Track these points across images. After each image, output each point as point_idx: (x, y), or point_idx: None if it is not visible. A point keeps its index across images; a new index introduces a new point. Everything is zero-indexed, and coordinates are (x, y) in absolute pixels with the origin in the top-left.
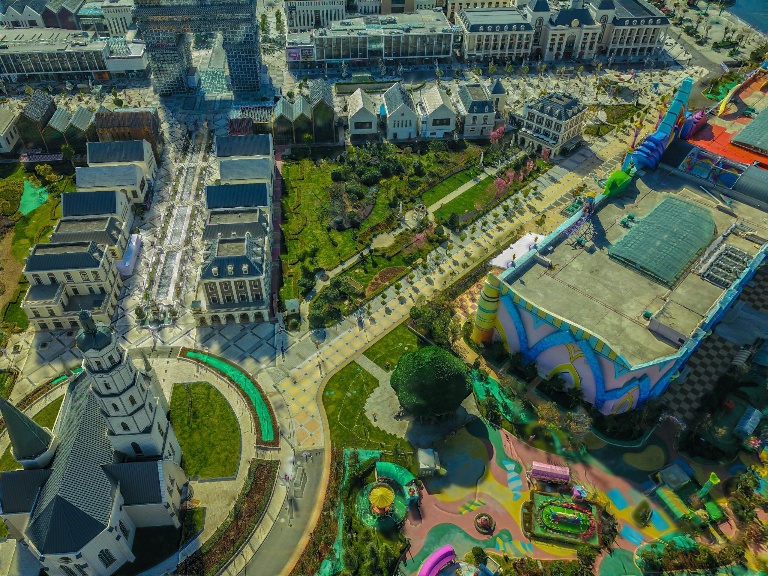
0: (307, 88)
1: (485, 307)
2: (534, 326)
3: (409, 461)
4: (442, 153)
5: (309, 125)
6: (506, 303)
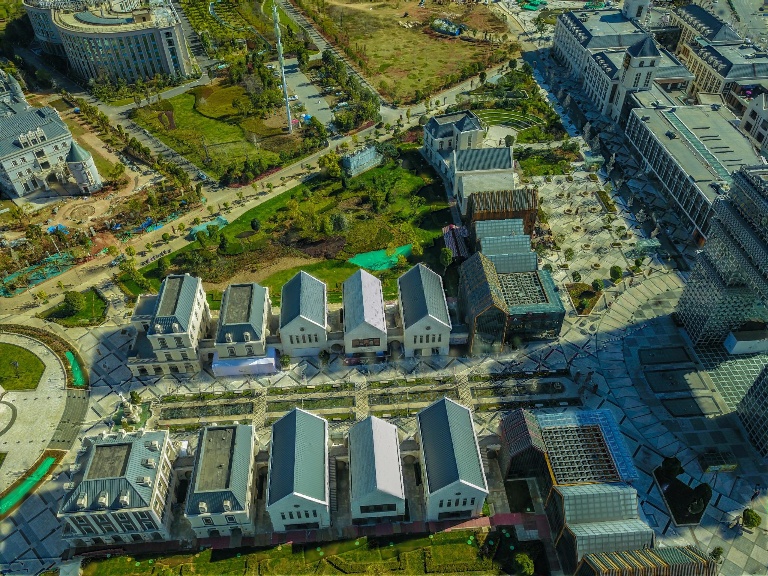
0: None
1: None
2: None
3: None
4: None
5: (575, 562)
6: None
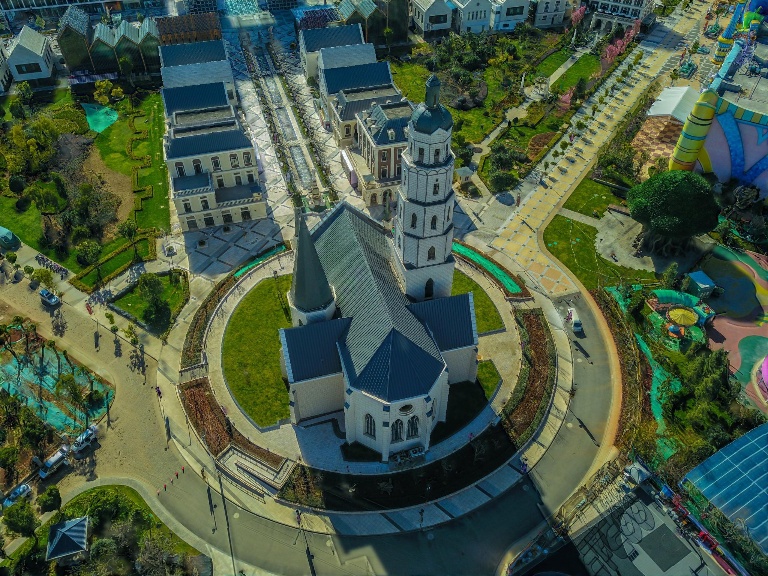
0: None
1: (696, 133)
2: (757, 142)
3: (687, 283)
4: None
5: (383, 22)
6: (725, 122)
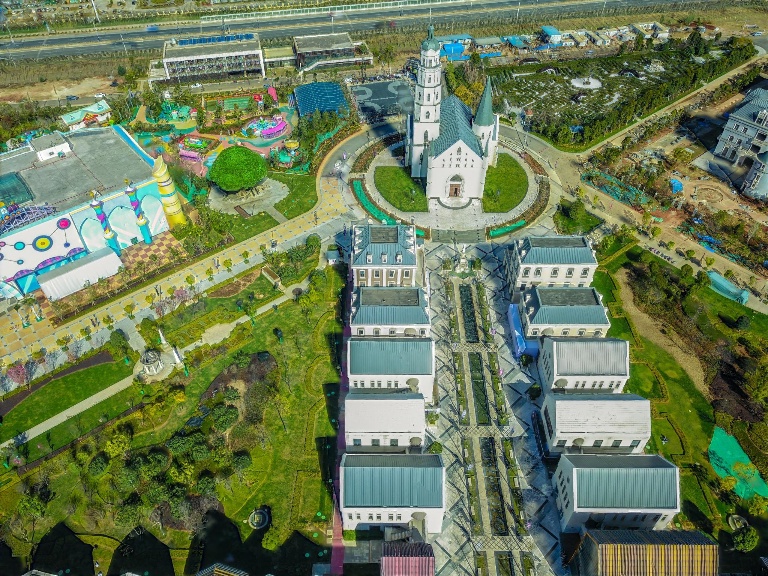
0: None
1: None
2: None
3: None
4: None
5: None
6: None
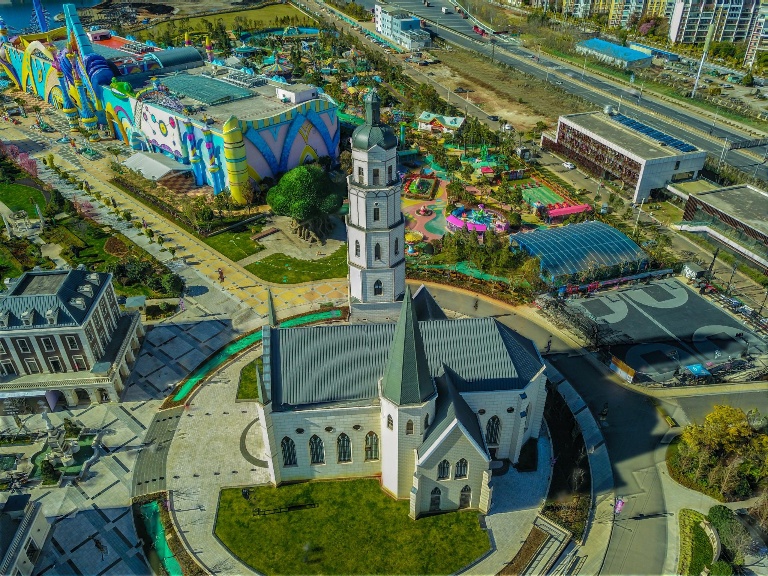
0: None
1: (242, 155)
2: (274, 139)
3: None
4: None
5: None
6: (252, 136)
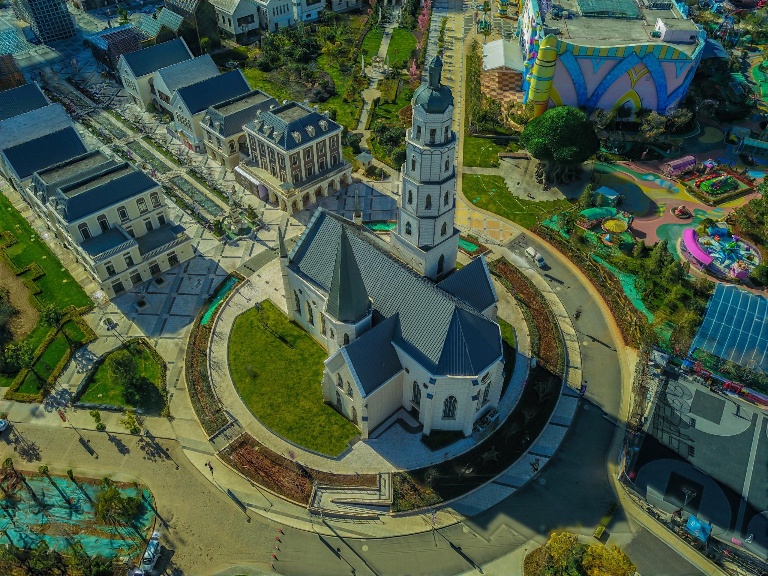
0: (129, 20)
1: (546, 75)
2: (594, 71)
3: (601, 199)
4: (333, 27)
5: (193, 33)
6: (567, 60)
